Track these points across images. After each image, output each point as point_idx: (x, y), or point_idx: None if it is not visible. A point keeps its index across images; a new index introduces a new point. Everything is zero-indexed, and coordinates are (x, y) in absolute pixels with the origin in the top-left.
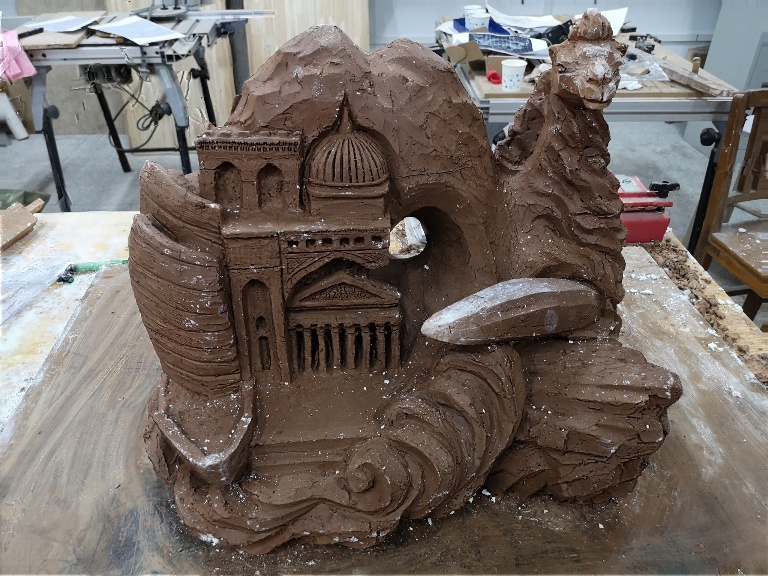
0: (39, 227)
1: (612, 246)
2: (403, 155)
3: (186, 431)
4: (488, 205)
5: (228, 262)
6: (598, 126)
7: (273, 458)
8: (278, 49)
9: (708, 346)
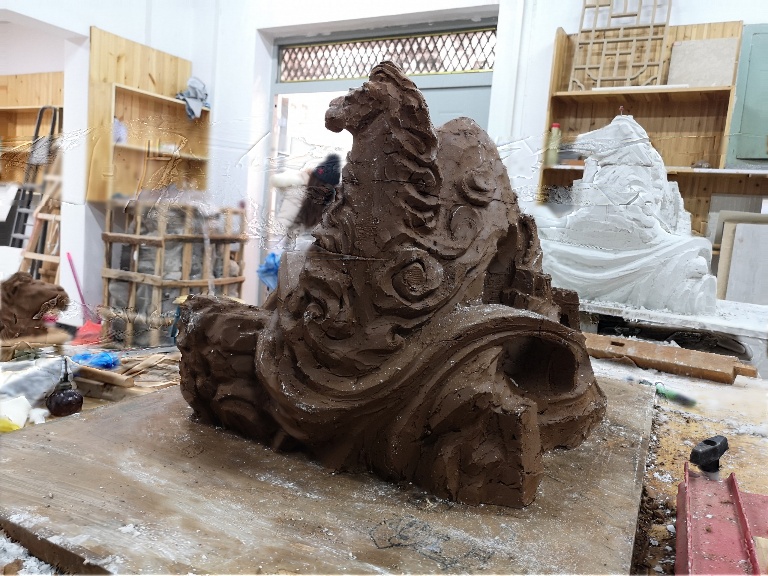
0: (738, 386)
1: None
2: None
3: None
4: None
5: None
6: None
7: None
8: None
9: (201, 575)
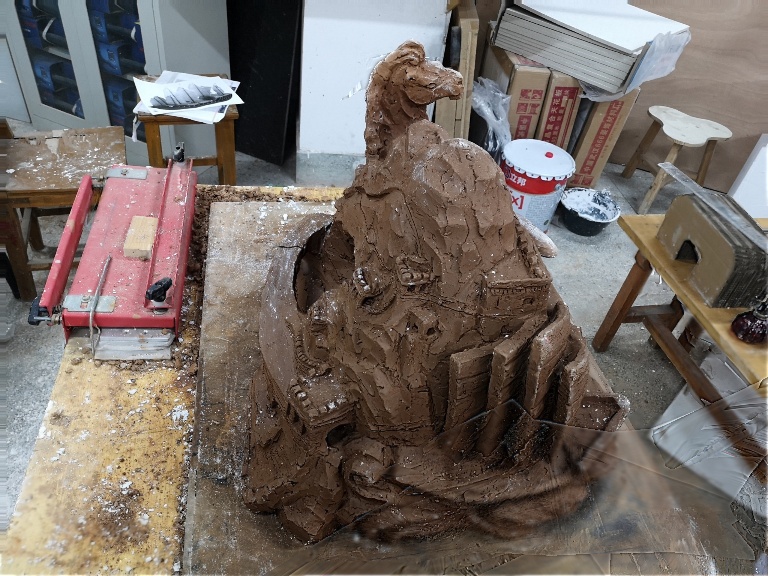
0: None
1: None
2: None
3: None
4: None
5: None
6: None
7: None
8: (488, 180)
9: None
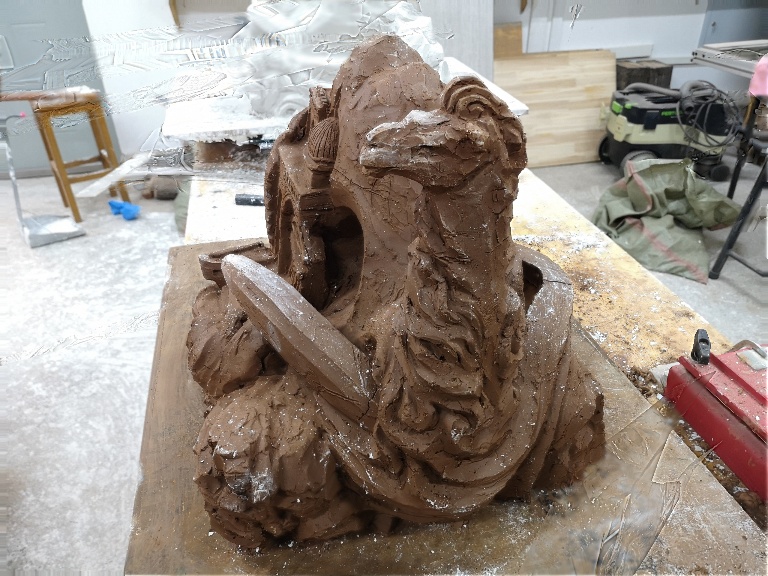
0: None
1: (406, 371)
2: (340, 151)
3: (243, 253)
4: (385, 245)
5: (279, 169)
6: (430, 217)
7: (226, 291)
8: None
9: None
